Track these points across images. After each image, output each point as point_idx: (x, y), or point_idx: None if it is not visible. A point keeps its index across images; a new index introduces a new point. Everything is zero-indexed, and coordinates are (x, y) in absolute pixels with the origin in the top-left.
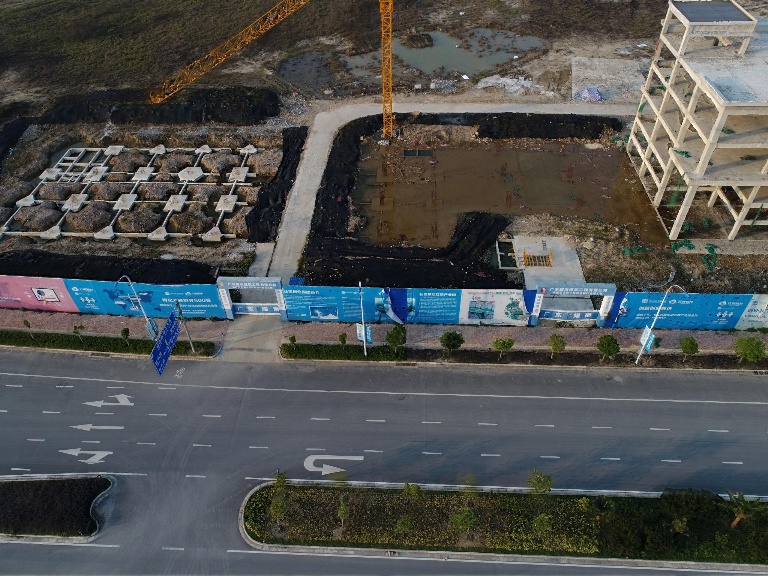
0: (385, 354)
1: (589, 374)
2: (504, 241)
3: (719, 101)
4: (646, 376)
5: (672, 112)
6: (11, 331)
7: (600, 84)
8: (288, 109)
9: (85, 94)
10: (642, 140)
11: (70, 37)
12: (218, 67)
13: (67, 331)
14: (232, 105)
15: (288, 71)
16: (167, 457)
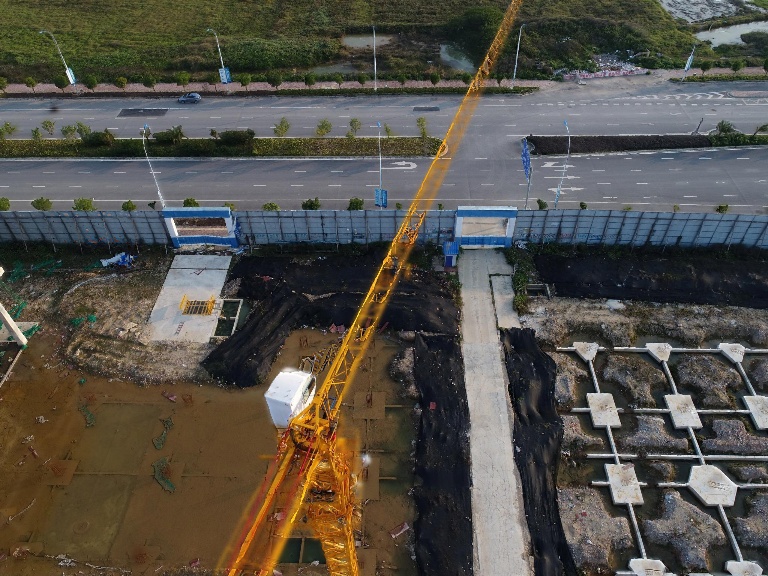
0: None
1: None
2: None
3: None
4: None
5: None
6: None
7: None
8: None
9: None
10: None
11: None
12: None
13: None
14: None
15: None
16: (504, 165)
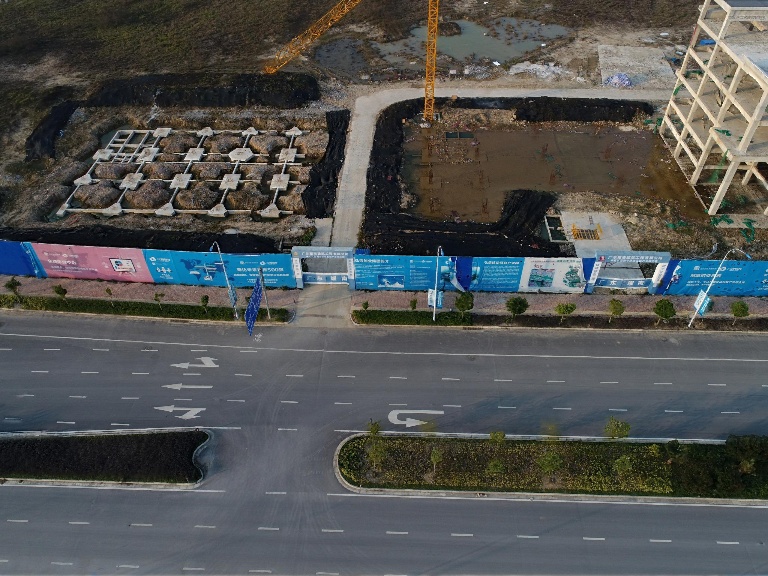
0: (452, 319)
1: (646, 336)
2: (552, 216)
3: (765, 80)
4: (699, 338)
5: (709, 94)
6: (91, 300)
7: (628, 70)
8: (328, 93)
9: (127, 78)
10: (675, 122)
11: (104, 24)
12: (254, 53)
13: (144, 300)
14: (274, 89)
15: (323, 57)
16: (258, 412)
